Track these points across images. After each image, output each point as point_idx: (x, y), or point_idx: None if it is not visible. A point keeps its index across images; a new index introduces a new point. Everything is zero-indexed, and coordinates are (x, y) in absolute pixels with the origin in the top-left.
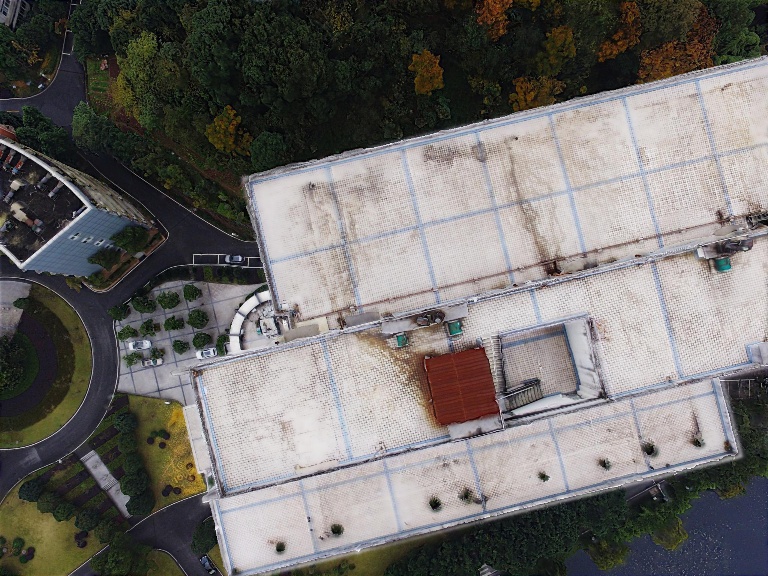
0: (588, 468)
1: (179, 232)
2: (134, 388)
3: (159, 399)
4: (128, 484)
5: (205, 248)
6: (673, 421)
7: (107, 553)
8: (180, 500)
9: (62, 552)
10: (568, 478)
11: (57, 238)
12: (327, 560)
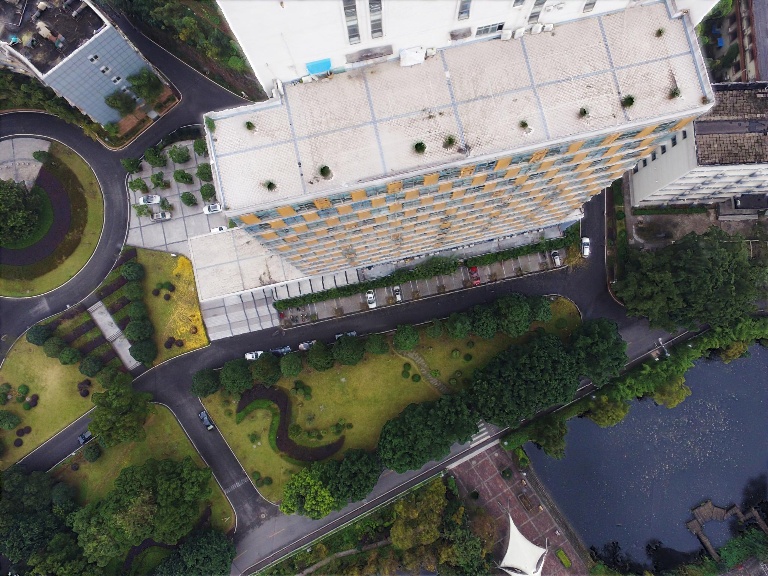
0: (569, 122)
1: (192, 94)
2: (142, 242)
3: (166, 252)
4: (132, 325)
5: (216, 109)
6: (652, 79)
7: (108, 392)
8: (182, 354)
9: (65, 400)
10: (550, 130)
11: (78, 52)
12: (325, 419)
